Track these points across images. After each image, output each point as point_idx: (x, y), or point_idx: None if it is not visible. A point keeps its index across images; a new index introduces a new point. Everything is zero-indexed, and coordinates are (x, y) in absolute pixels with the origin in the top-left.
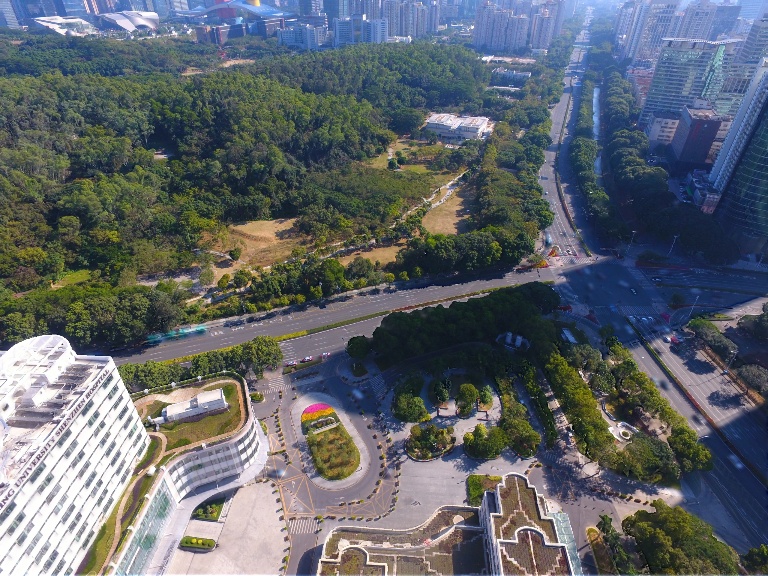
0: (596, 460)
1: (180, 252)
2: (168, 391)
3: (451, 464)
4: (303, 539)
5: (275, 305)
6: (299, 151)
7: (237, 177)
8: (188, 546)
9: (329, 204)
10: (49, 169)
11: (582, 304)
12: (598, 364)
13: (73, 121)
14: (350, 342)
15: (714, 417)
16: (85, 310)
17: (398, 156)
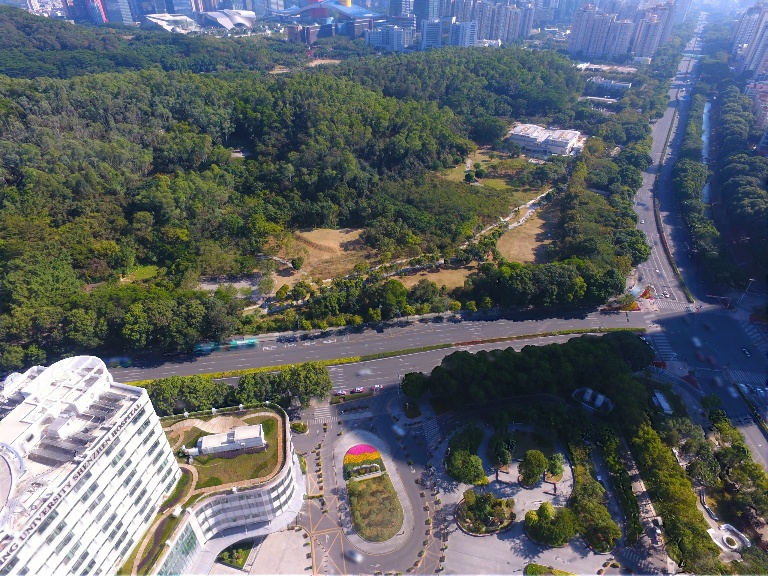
0: (690, 571)
1: (244, 256)
2: (208, 417)
3: (508, 545)
4: None
5: (331, 323)
6: (373, 158)
7: (308, 182)
8: None
9: (398, 217)
10: (134, 162)
11: (680, 361)
12: (700, 445)
13: (162, 116)
14: (405, 378)
15: None
16: (143, 313)
17: (476, 168)
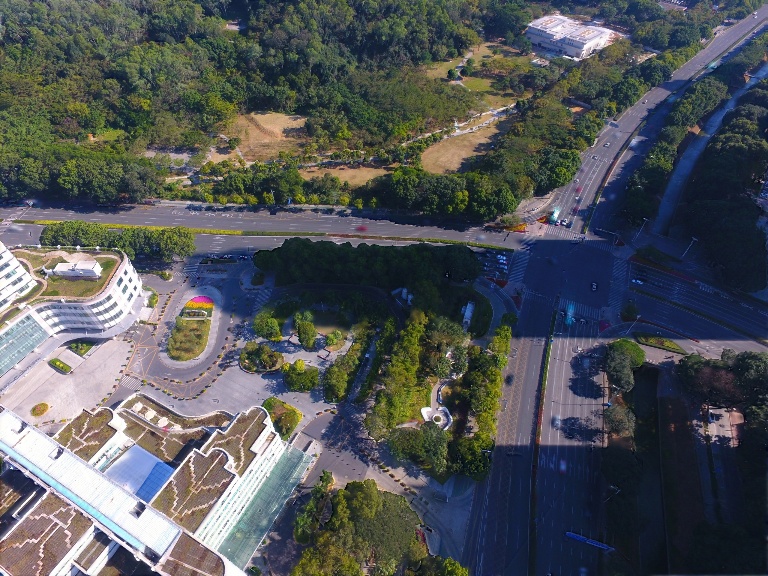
0: None
1: (196, 130)
2: (73, 251)
3: (266, 382)
4: (124, 391)
5: None
6: (356, 43)
7: (273, 64)
8: (53, 365)
9: (341, 110)
10: (128, 28)
11: (522, 283)
12: (456, 347)
13: None
14: (255, 253)
15: (547, 440)
16: (75, 168)
17: (467, 64)
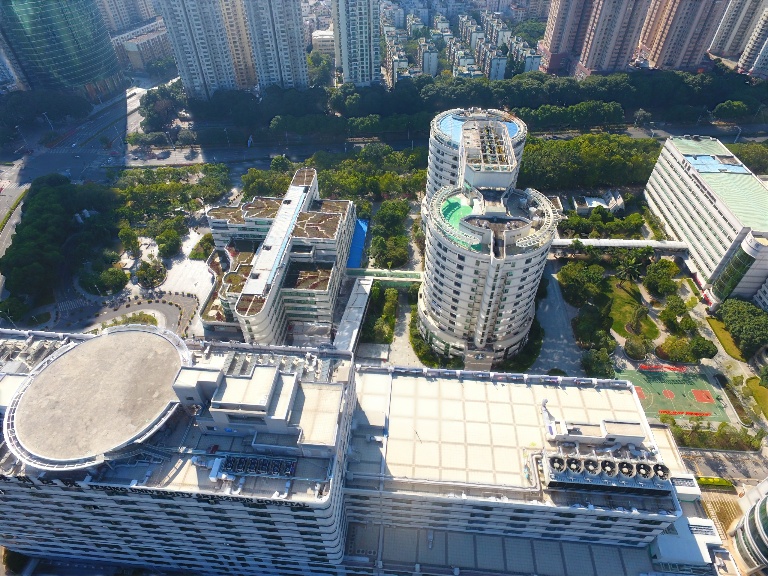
0: (204, 206)
1: None
2: None
3: (175, 266)
4: None
5: None
6: None
7: None
8: None
9: None
10: None
11: None
12: None
13: None
14: (4, 309)
15: None
16: None
17: None
